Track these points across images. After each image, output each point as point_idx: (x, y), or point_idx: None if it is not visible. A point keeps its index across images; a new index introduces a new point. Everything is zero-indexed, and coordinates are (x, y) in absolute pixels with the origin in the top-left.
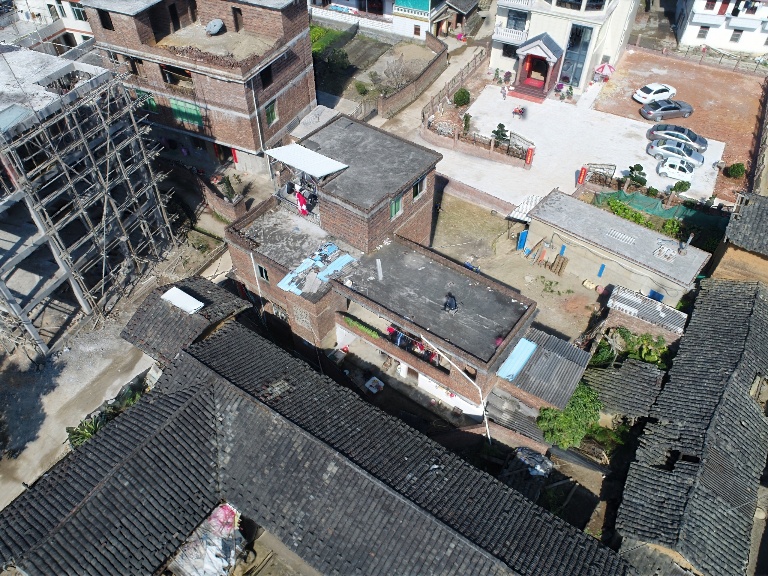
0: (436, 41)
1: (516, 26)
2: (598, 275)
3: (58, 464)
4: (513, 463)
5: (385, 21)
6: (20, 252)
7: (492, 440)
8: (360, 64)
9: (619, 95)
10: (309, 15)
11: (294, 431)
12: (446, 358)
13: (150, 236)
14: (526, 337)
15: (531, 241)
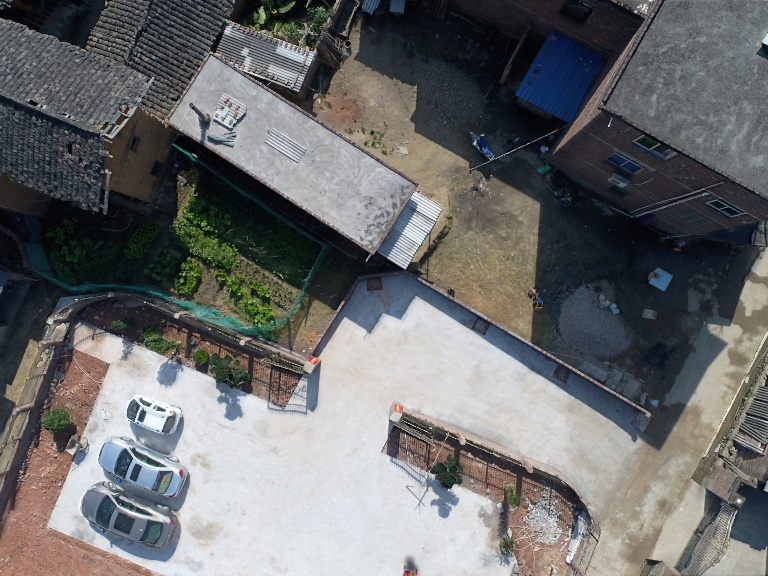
0: None
1: None
2: None
3: None
4: None
5: None
6: None
7: None
8: None
9: None
10: None
11: None
12: None
13: None
14: None
15: None
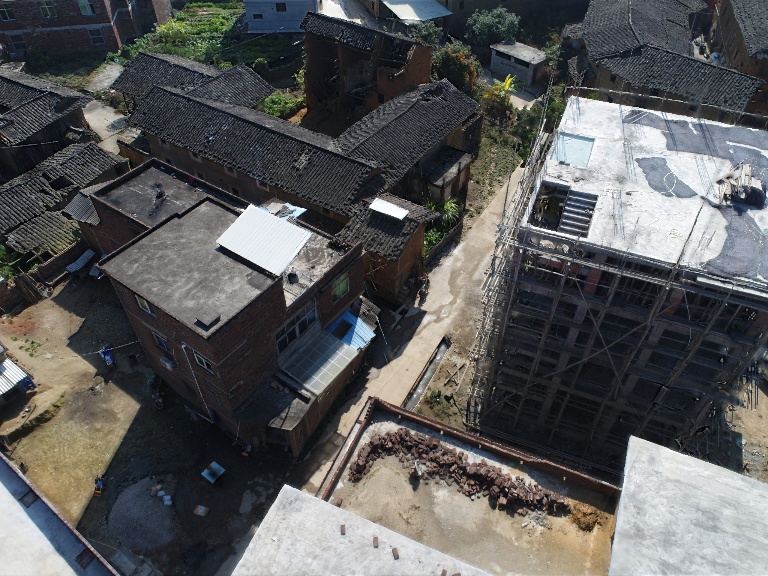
0: None
1: None
2: None
3: (451, 180)
4: None
5: None
6: None
7: None
8: None
9: None
10: None
11: None
12: None
13: None
14: None
15: None
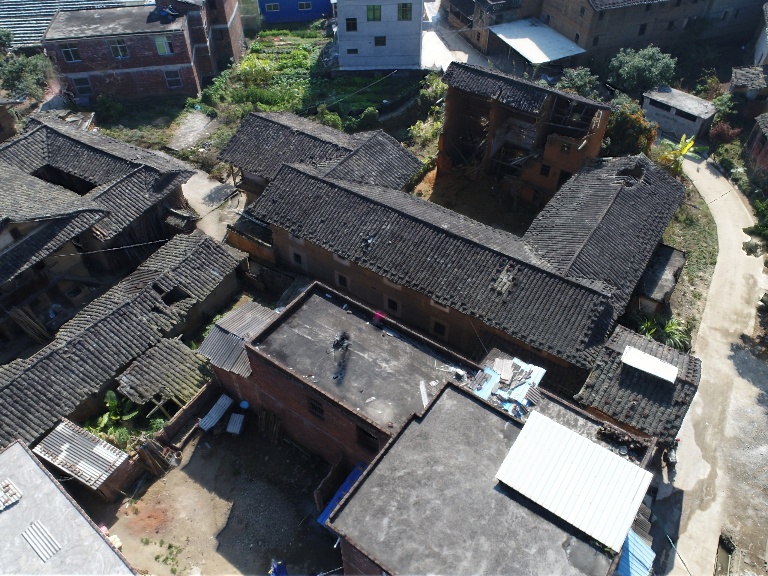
0: None
1: None
2: None
3: (671, 292)
4: None
5: None
6: None
7: None
8: None
9: None
10: None
11: None
12: None
13: None
14: None
15: None
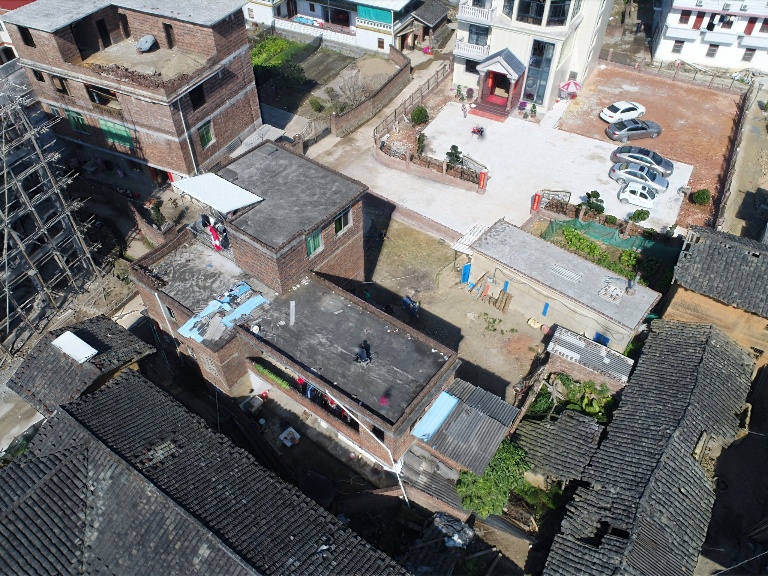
0: (399, 55)
1: (479, 41)
2: (543, 314)
3: None
4: (428, 532)
5: (348, 34)
6: None
7: (411, 502)
8: (320, 79)
9: (586, 113)
10: (272, 27)
11: (168, 505)
12: (353, 417)
13: (66, 268)
14: (448, 390)
15: (474, 275)
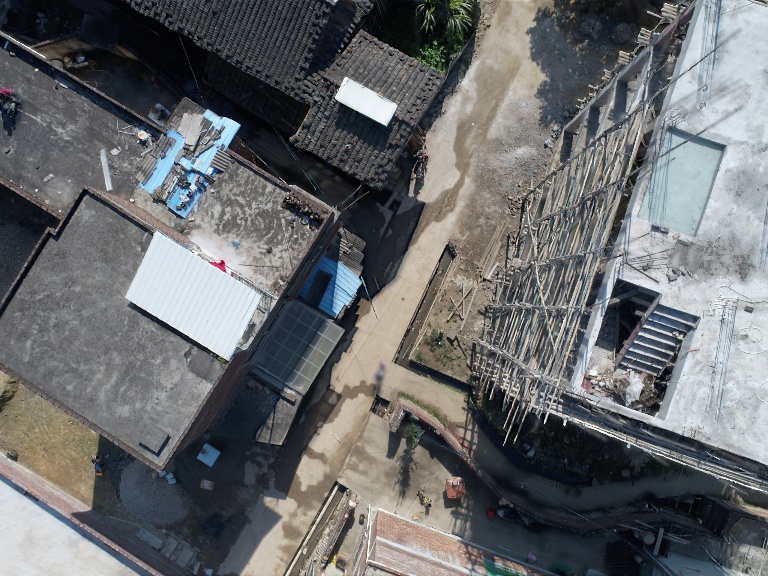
0: None
1: None
2: None
3: None
4: (1, 18)
5: None
6: (606, 122)
7: None
8: None
9: None
10: None
11: None
12: None
13: None
14: None
15: None
